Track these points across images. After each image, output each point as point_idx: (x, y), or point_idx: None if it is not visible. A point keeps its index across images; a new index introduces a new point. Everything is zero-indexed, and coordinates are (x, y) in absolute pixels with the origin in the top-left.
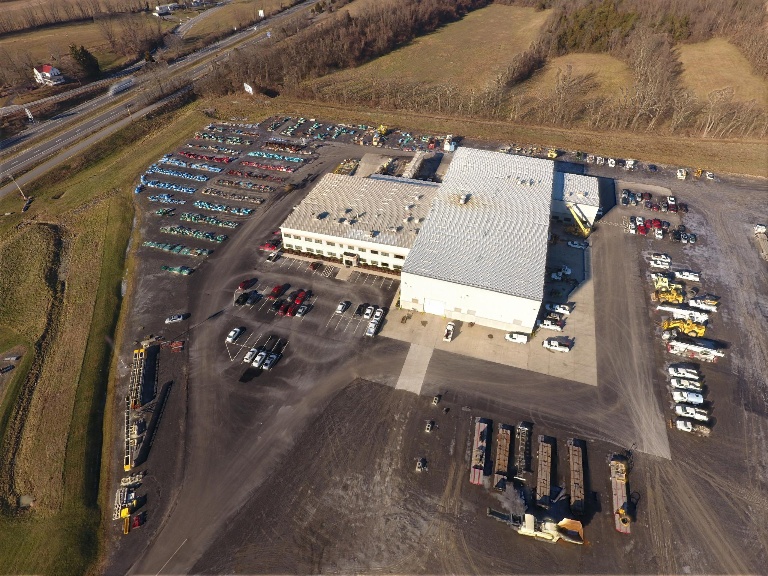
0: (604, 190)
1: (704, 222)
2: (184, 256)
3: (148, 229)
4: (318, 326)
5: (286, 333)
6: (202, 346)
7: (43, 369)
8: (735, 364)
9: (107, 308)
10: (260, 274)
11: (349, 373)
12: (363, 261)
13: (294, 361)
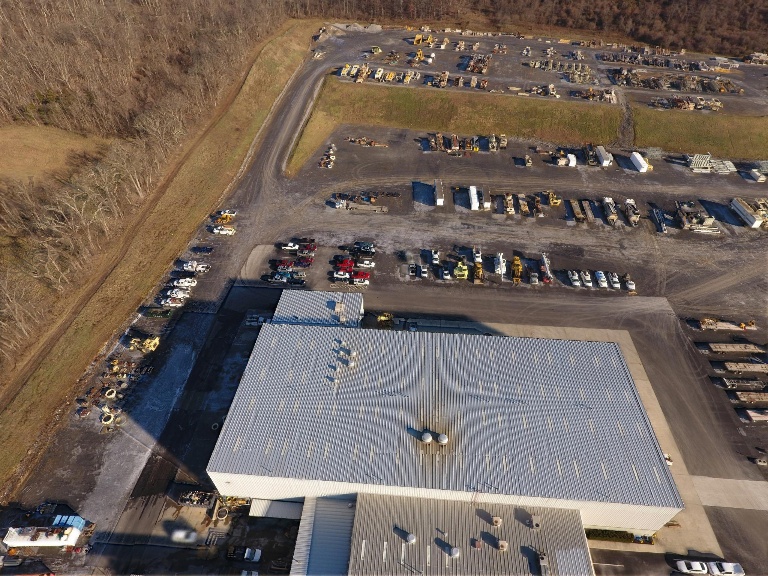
0: (266, 297)
1: (329, 233)
2: None
3: None
4: None
5: None
6: None
7: None
8: (538, 252)
9: None
10: None
11: None
12: None
13: None
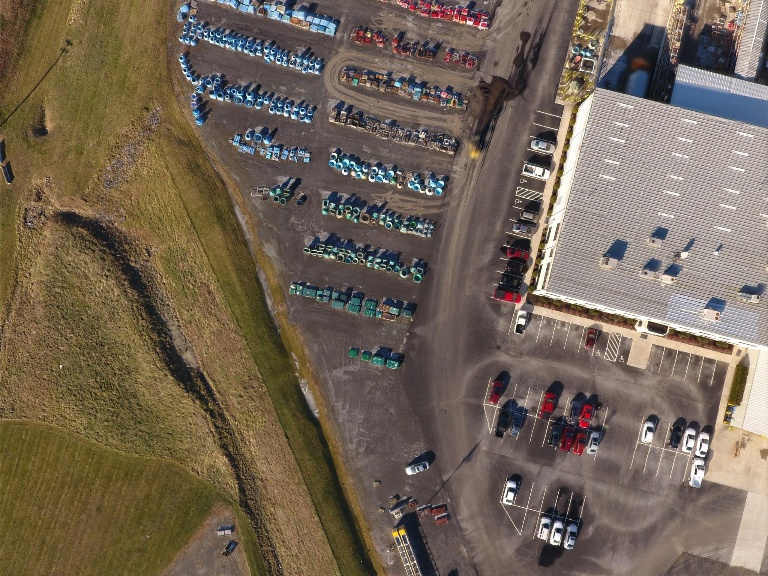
0: None
1: None
2: (373, 321)
3: (279, 247)
4: (620, 468)
5: (579, 483)
6: (473, 512)
7: (275, 543)
8: None
9: (310, 449)
10: (510, 361)
11: (672, 546)
12: (670, 327)
13: (600, 531)
